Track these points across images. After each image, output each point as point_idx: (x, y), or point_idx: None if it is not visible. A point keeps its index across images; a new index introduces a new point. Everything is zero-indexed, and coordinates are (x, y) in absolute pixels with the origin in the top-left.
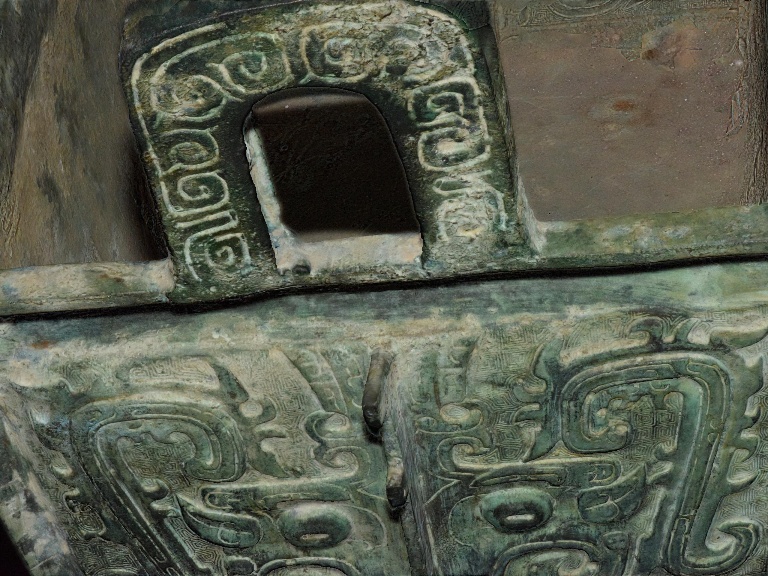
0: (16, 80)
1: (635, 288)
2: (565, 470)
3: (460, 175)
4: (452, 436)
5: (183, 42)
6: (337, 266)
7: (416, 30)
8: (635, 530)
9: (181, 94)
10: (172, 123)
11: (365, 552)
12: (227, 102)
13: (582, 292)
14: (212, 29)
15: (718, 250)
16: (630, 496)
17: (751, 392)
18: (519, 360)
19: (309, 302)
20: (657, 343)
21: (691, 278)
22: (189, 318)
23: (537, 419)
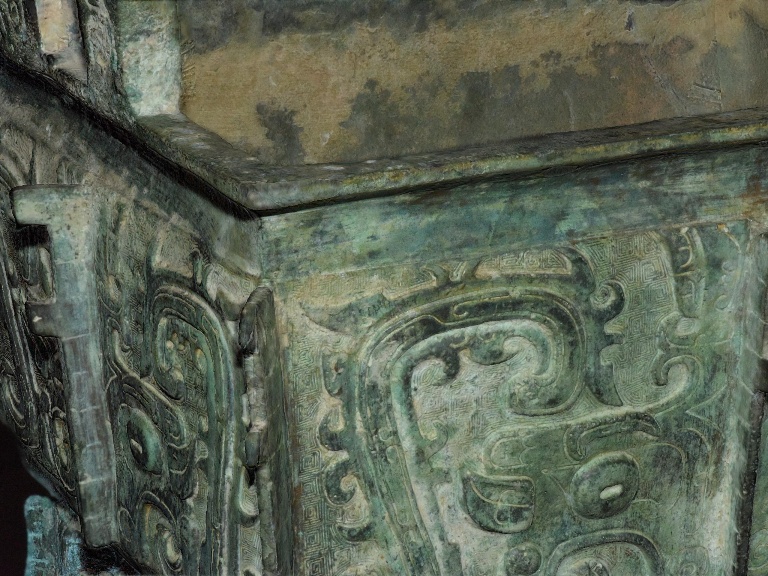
0: (268, 0)
1: None
2: (156, 405)
3: None
4: None
5: None
6: None
7: None
8: None
9: None
10: None
11: None
12: None
13: (185, 203)
14: None
15: None
16: None
17: None
18: None
19: None
20: (194, 280)
21: None
22: (47, 106)
23: None
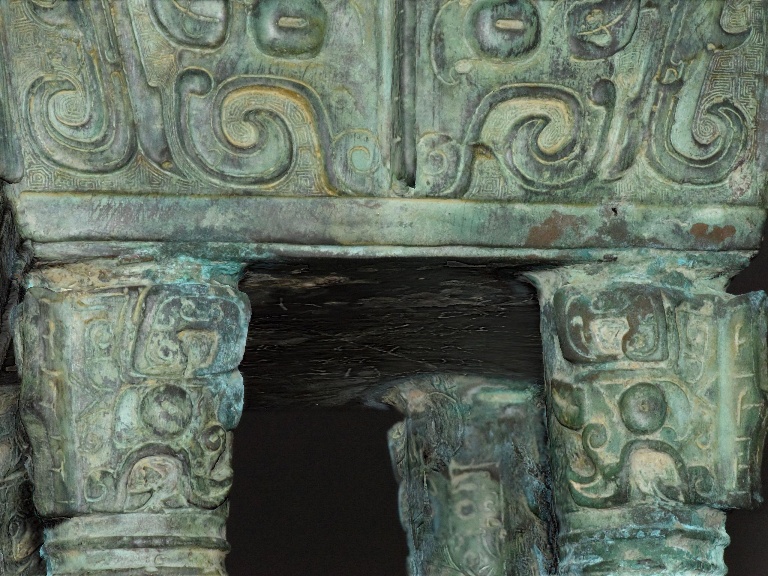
0: None
1: None
2: None
3: None
4: None
5: None
6: None
7: None
8: None
9: None
10: None
11: None
12: None
13: None
14: None
15: None
16: None
17: None
18: None
19: None
20: None
21: None
22: None
23: None
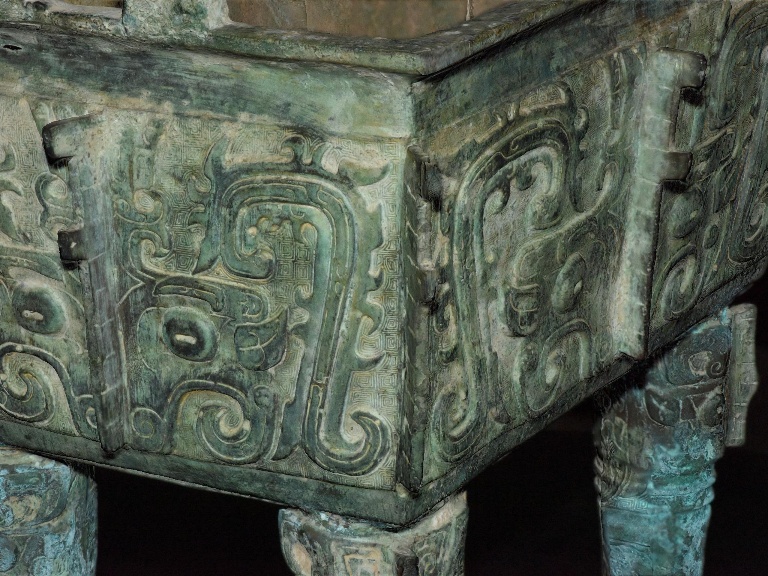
0: None
1: (293, 106)
2: (223, 292)
3: None
4: (140, 227)
5: None
6: (68, 11)
7: None
8: (282, 392)
9: None
10: None
11: (76, 356)
12: None
13: (254, 101)
14: None
15: (336, 54)
16: (274, 342)
17: (373, 245)
18: (195, 156)
19: (61, 66)
20: (298, 163)
21: (334, 103)
22: None
23: (202, 223)
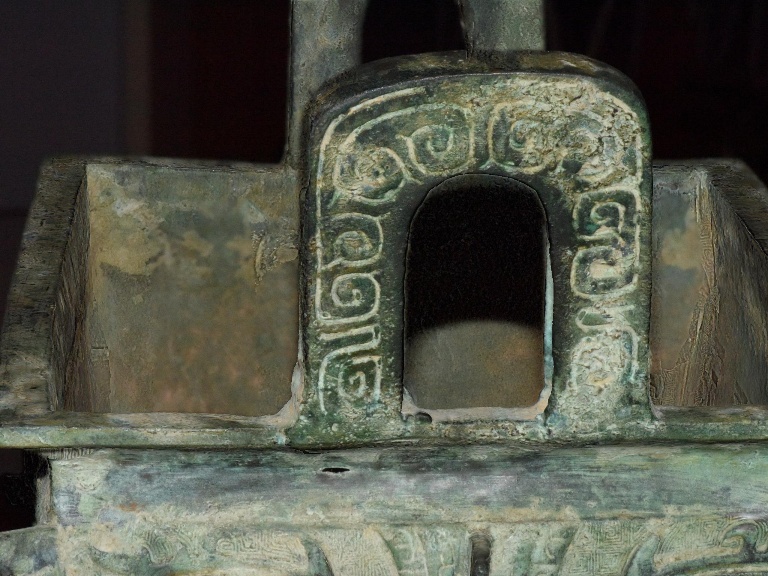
0: None
1: (733, 490)
2: None
3: (604, 307)
4: None
5: (381, 105)
6: (458, 420)
7: (599, 121)
8: None
9: (364, 168)
10: (347, 203)
11: None
12: (405, 184)
13: (681, 491)
14: (411, 93)
15: None
16: None
17: None
18: (612, 562)
19: (409, 483)
20: (750, 552)
21: None
22: (284, 492)
23: None
